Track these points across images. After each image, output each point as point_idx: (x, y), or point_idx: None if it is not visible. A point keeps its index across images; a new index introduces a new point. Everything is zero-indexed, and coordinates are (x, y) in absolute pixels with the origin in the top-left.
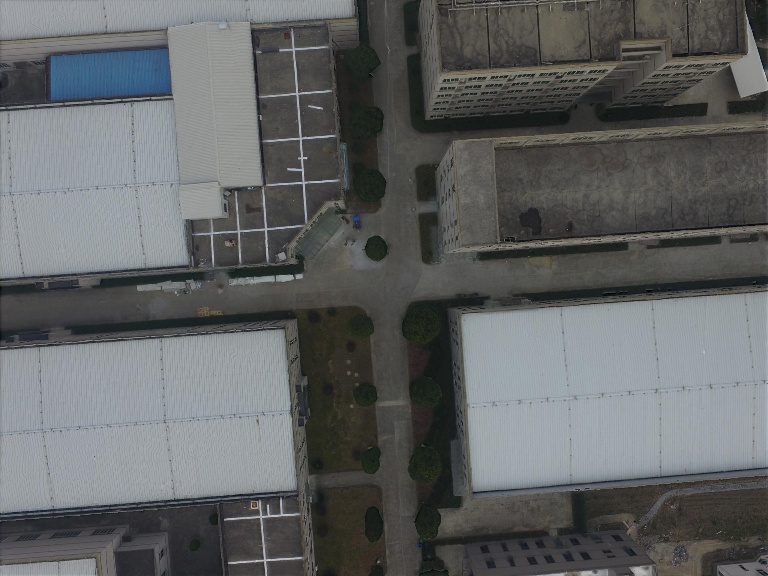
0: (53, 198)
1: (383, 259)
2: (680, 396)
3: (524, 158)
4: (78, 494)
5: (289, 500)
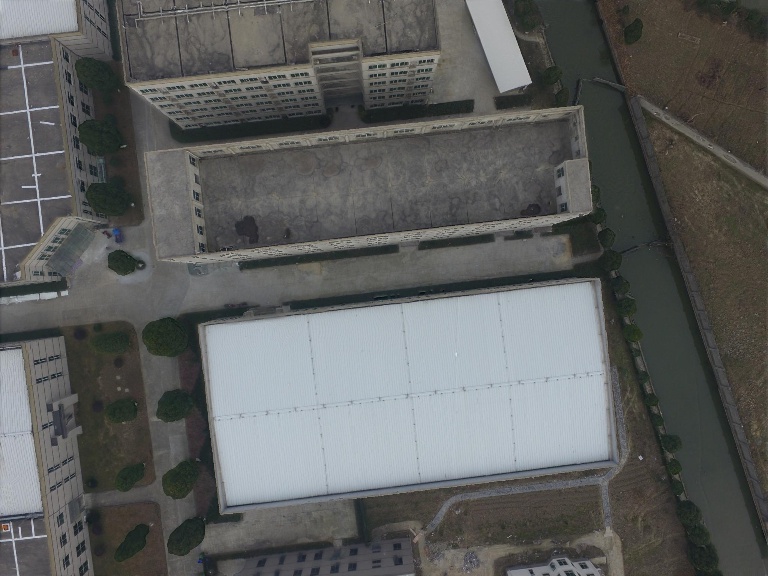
0: None
1: (149, 272)
2: (433, 400)
3: (237, 166)
4: None
5: (40, 521)
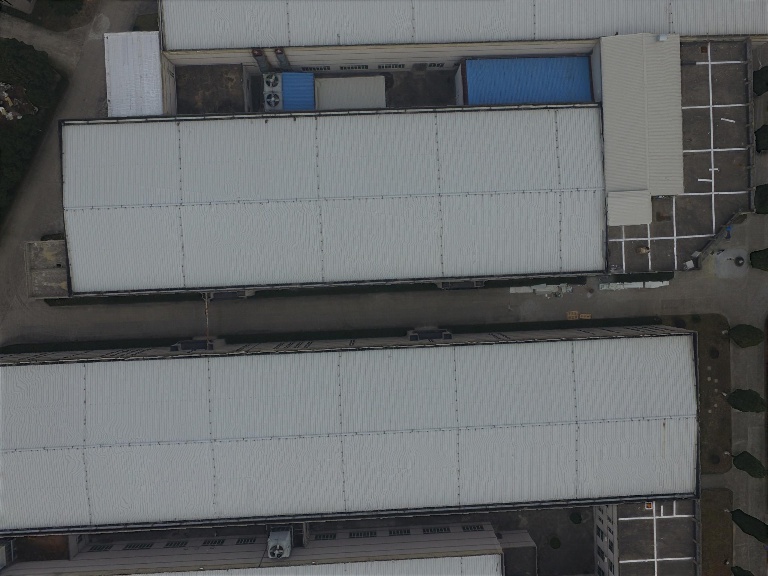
0: (480, 200)
1: (746, 269)
2: None
3: None
4: (492, 491)
5: (683, 502)
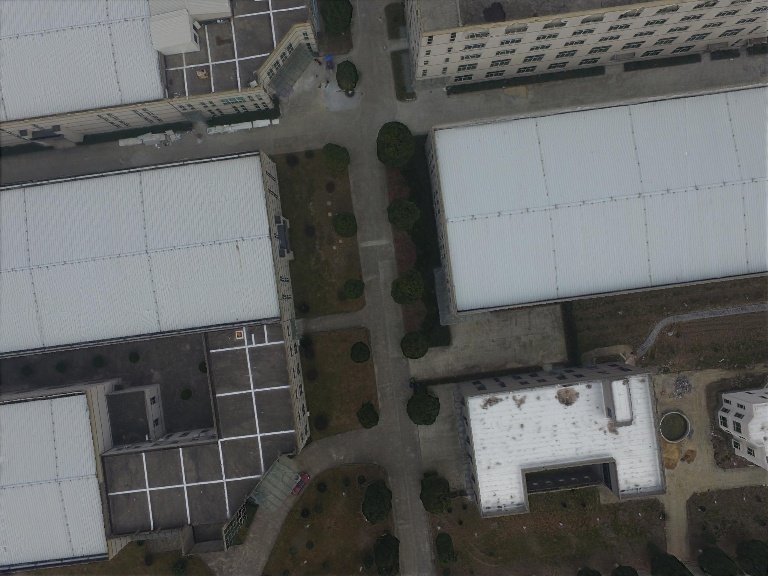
0: (31, 41)
1: (358, 99)
2: (665, 200)
3: None
4: (66, 327)
5: (273, 328)
